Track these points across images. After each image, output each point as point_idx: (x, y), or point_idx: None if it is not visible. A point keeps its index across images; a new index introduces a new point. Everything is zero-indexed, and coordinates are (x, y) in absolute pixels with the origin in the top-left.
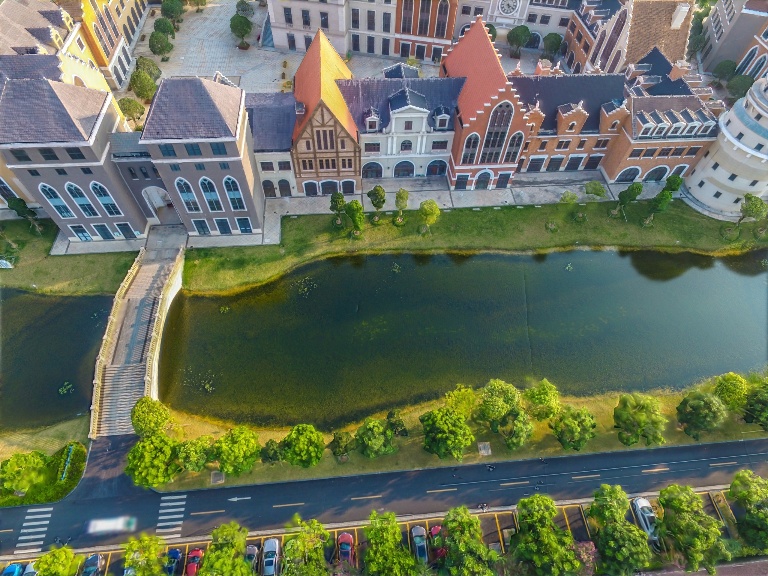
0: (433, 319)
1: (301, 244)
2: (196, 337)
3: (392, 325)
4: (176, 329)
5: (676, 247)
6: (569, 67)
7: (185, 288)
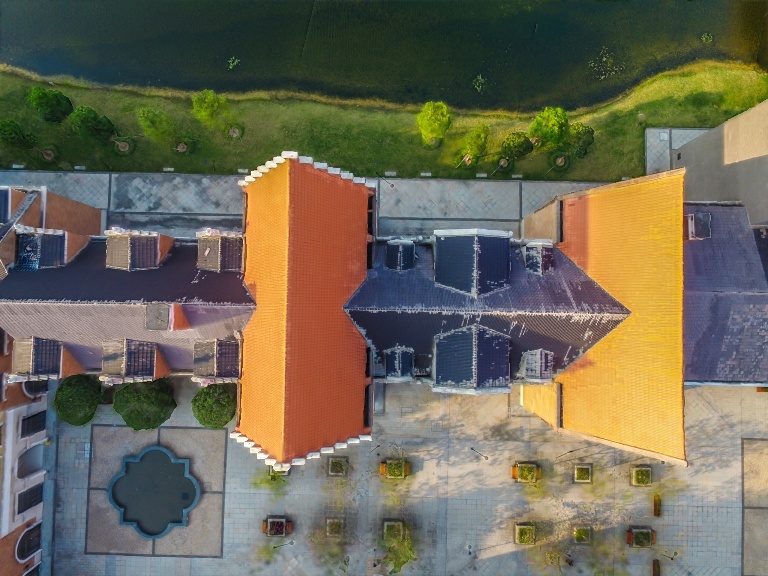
0: (440, 3)
1: (614, 128)
2: (736, 5)
3: (494, 1)
4: (763, 16)
5: (56, 84)
6: (38, 575)
7: (763, 74)
